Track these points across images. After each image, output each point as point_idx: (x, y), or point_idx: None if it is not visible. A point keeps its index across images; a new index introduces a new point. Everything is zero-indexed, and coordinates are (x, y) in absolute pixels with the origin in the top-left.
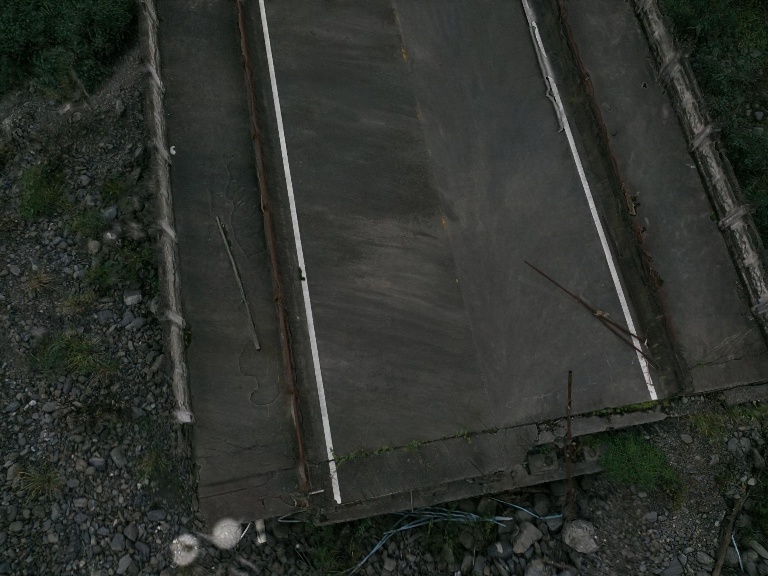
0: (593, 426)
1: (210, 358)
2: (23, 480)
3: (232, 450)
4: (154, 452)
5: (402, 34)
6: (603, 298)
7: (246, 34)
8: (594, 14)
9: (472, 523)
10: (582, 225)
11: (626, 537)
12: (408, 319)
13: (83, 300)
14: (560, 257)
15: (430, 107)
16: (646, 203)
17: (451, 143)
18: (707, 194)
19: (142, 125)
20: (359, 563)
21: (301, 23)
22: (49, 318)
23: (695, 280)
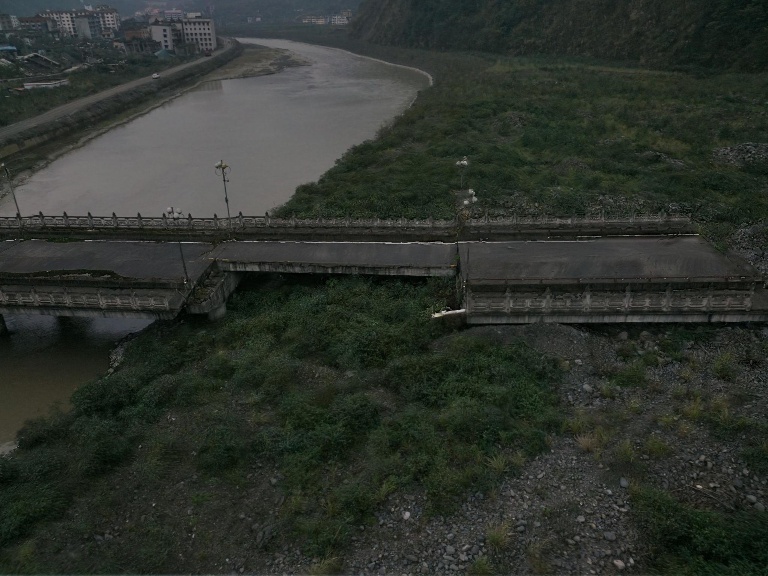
0: None
1: (720, 298)
2: None
3: None
4: None
5: None
6: None
7: None
8: None
9: None
10: None
11: None
12: None
13: None
14: None
15: None
16: None
17: None
18: None
19: None
20: None
21: None
22: None
23: None
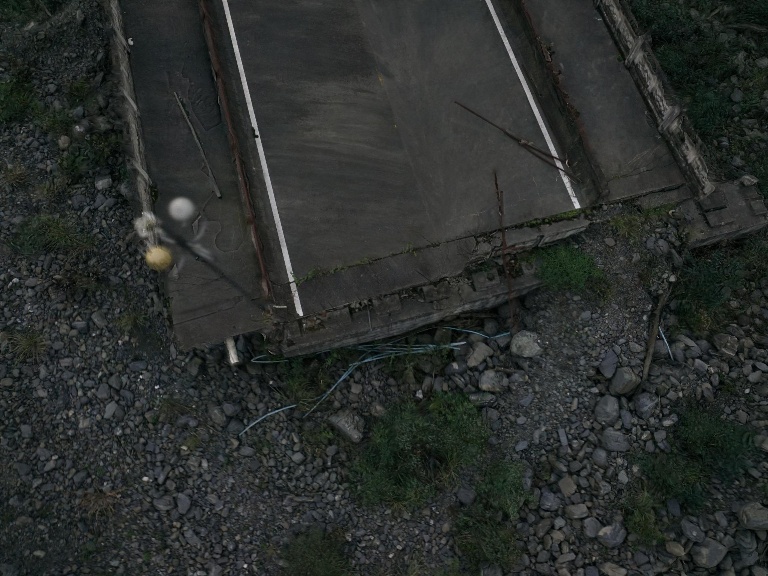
0: (525, 235)
1: (176, 209)
2: (11, 344)
3: (201, 282)
4: (132, 315)
5: None
6: (527, 130)
7: None
8: None
9: (430, 352)
10: (504, 73)
11: (565, 337)
12: (354, 161)
13: (57, 194)
14: (486, 100)
15: None
16: (560, 51)
17: (383, 15)
18: (613, 40)
19: (102, 32)
20: (328, 391)
21: None
22: (26, 208)
23: (607, 110)
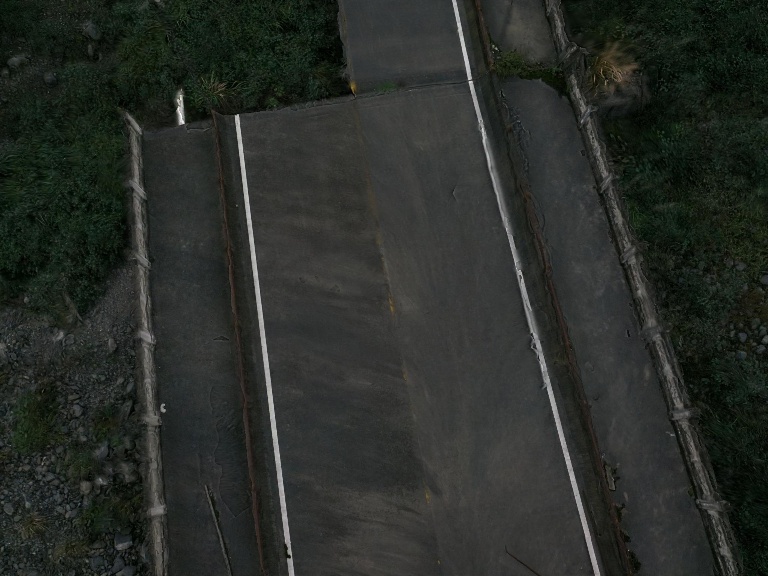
0: None
1: None
2: None
3: None
4: None
5: (390, 283)
6: None
7: (236, 287)
8: (579, 261)
9: None
10: (562, 501)
11: None
12: None
13: (75, 534)
14: (540, 537)
15: (416, 367)
16: (626, 476)
17: (436, 408)
18: (686, 466)
19: (134, 360)
20: None
21: (291, 265)
22: (41, 561)
23: (672, 563)
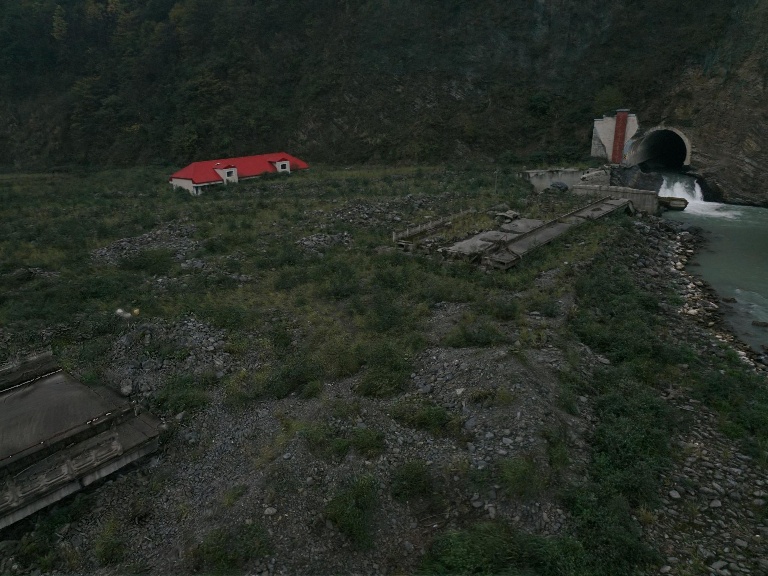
0: None
1: (84, 454)
2: None
3: None
4: None
5: None
6: None
7: None
8: None
9: None
10: None
11: None
12: (43, 418)
13: None
14: None
15: None
16: None
17: None
18: None
19: None
20: None
21: None
22: (86, 568)
23: None
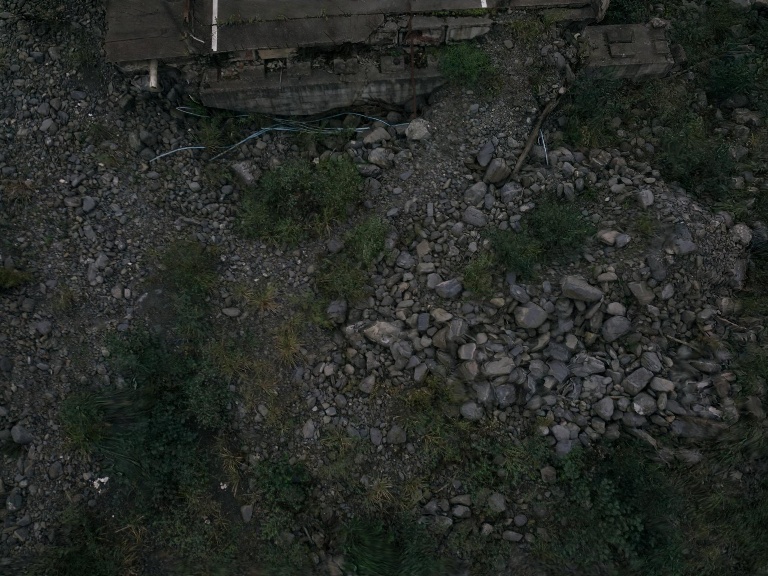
0: (431, 22)
1: None
2: None
3: (137, 13)
4: (85, 58)
5: None
6: None
7: None
8: None
9: (337, 133)
10: None
11: (452, 124)
12: None
13: None
14: None
15: None
16: None
17: None
18: None
19: None
20: (237, 143)
21: None
22: None
23: None
